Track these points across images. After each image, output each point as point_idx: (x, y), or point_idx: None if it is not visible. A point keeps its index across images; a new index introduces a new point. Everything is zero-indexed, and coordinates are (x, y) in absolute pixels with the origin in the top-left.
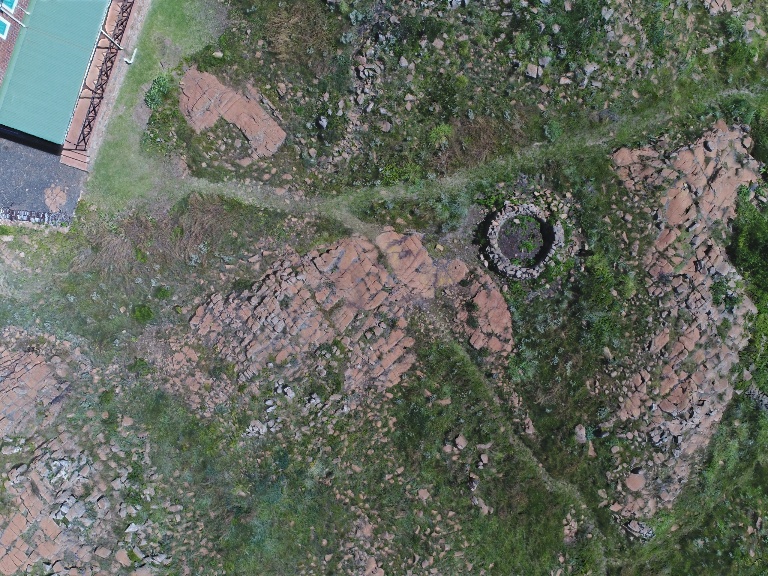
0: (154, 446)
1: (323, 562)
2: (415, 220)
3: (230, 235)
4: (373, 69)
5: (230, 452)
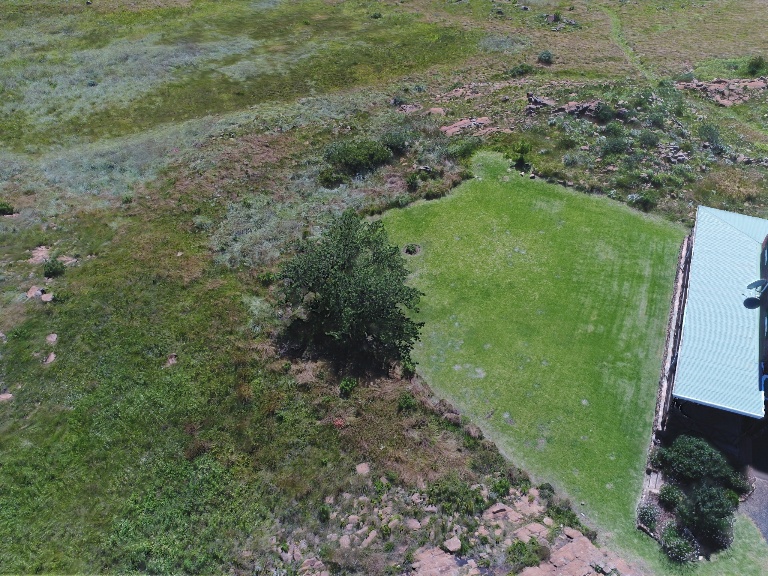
0: None
1: None
2: None
3: None
4: None
5: None
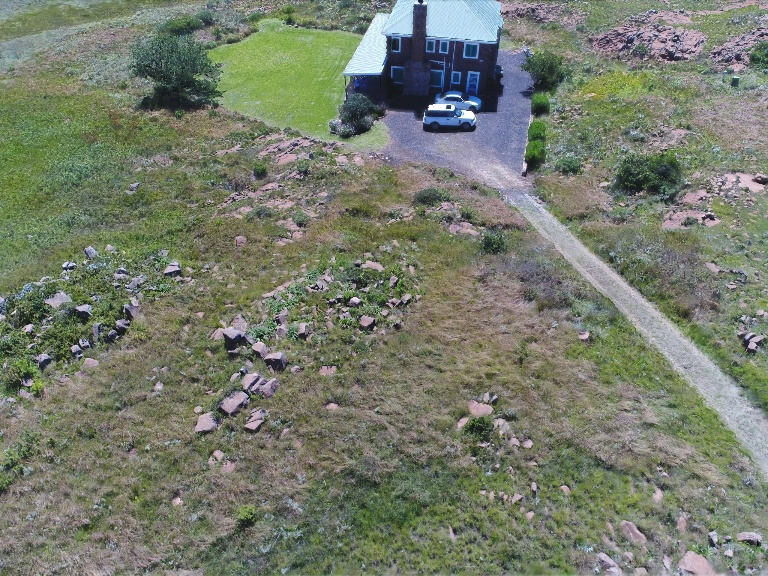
0: None
1: None
2: None
3: None
4: None
5: None
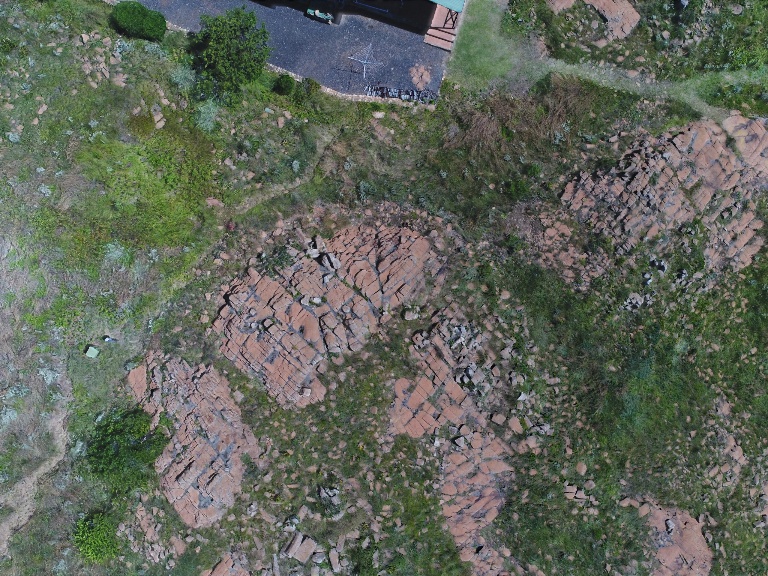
0: (530, 320)
1: (688, 438)
2: (759, 105)
3: (589, 115)
4: None
5: (603, 326)
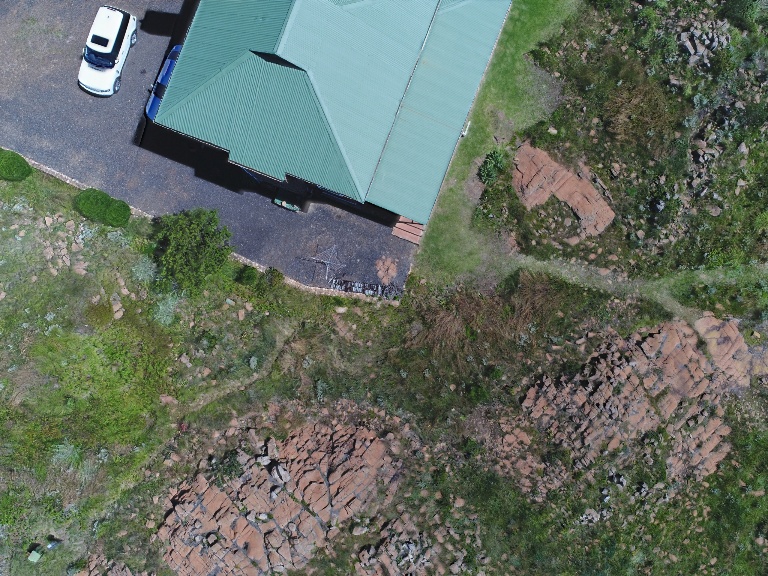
0: (483, 528)
1: None
2: (734, 306)
3: (556, 315)
4: (712, 154)
5: (558, 538)
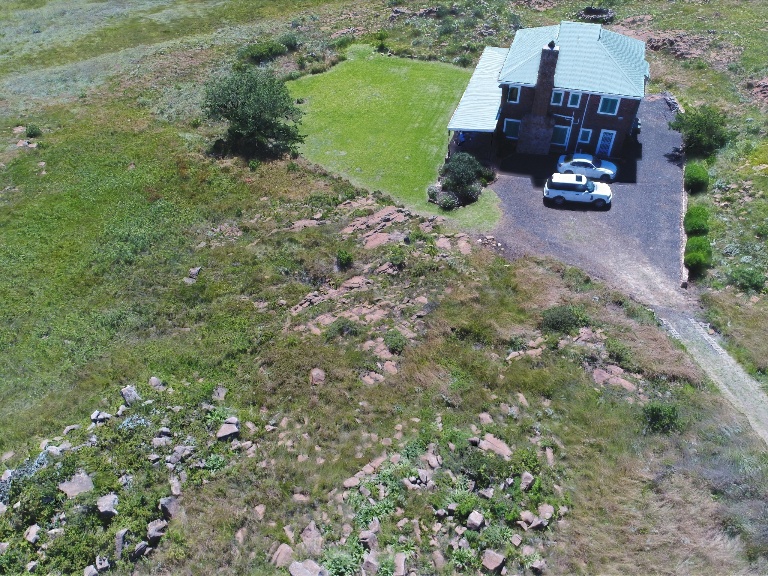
0: None
1: None
2: None
3: None
4: None
5: None
